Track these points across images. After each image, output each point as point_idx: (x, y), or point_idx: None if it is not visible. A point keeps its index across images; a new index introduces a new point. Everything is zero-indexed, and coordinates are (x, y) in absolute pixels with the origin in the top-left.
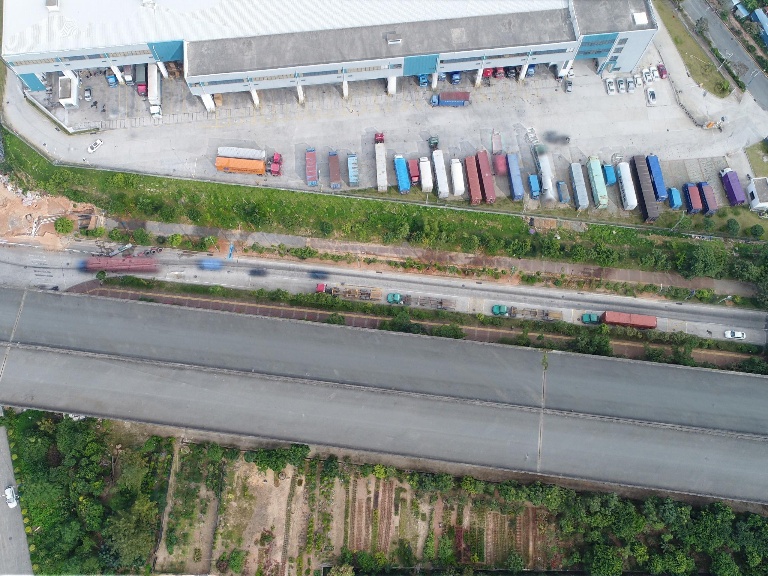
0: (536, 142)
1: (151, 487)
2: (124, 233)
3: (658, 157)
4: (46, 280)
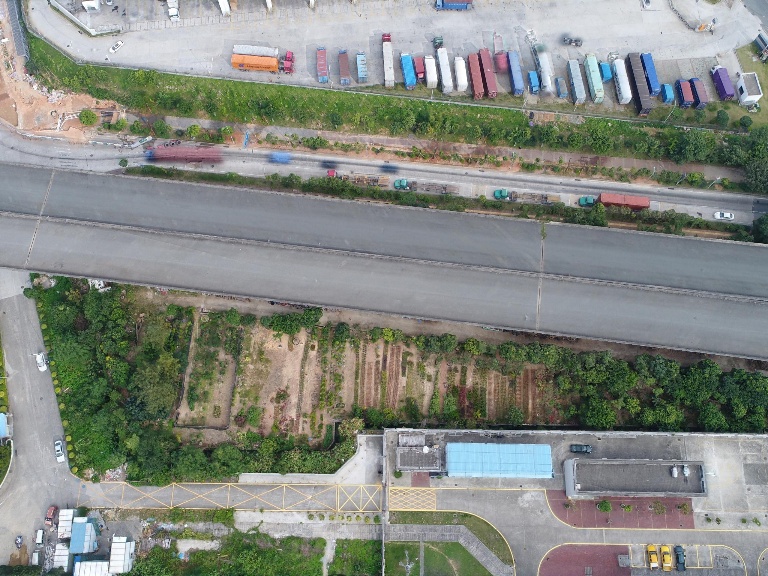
0: (536, 43)
1: (173, 351)
2: (144, 127)
3: (652, 57)
4: None
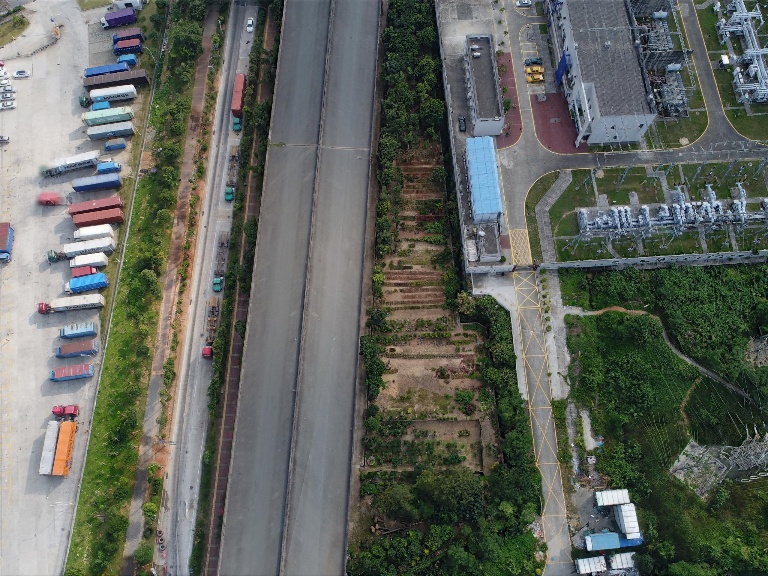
0: (61, 168)
1: None
2: None
3: None
4: None
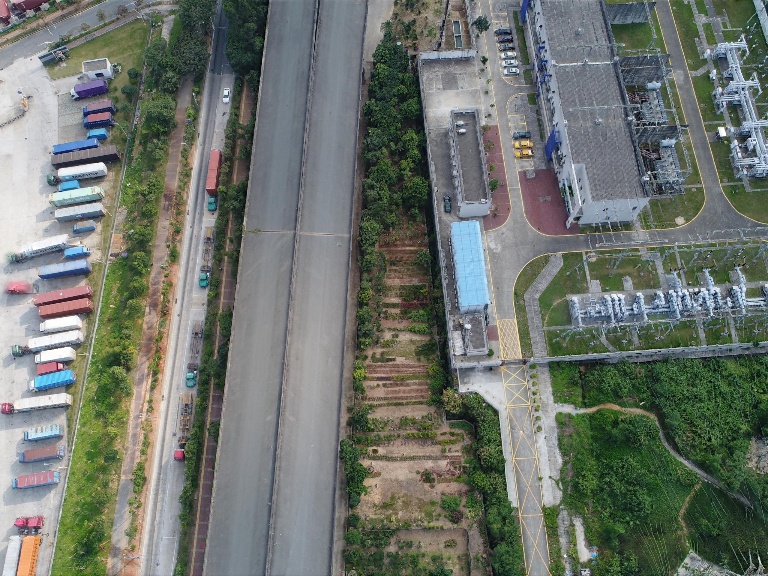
0: (28, 253)
1: None
2: None
3: None
4: None
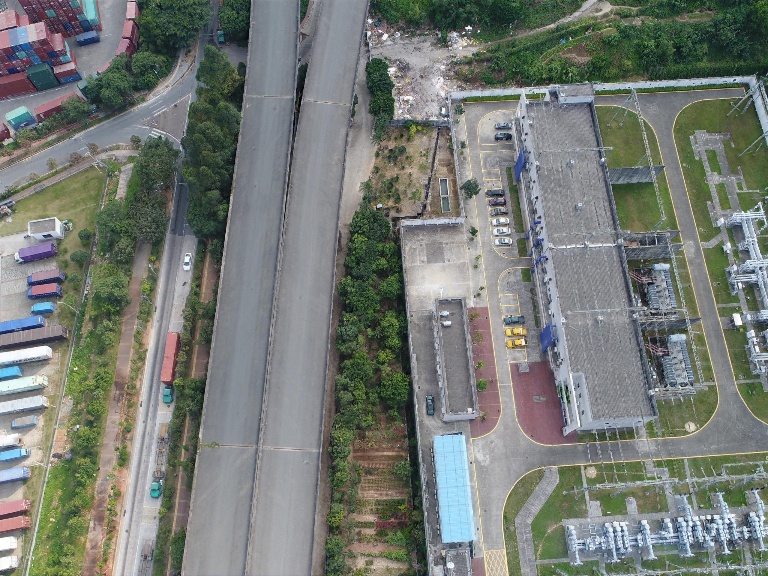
0: None
1: None
2: None
3: None
4: None
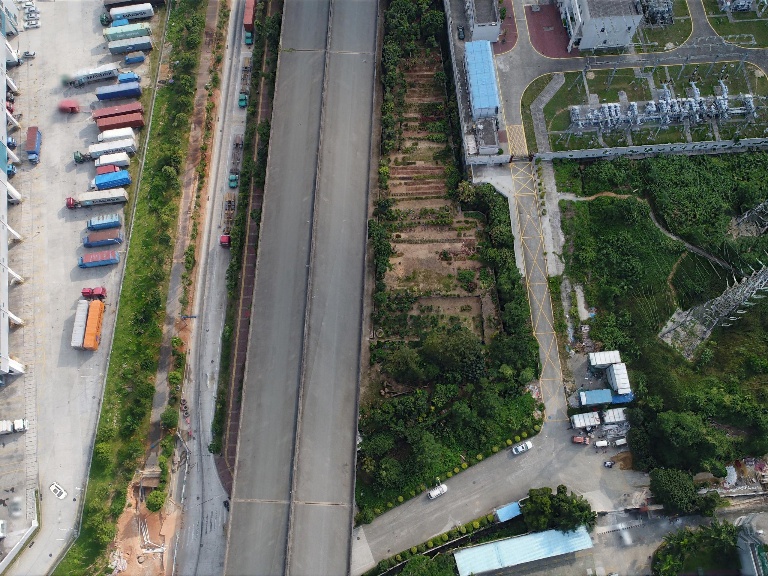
0: (84, 80)
1: None
2: None
3: None
4: (217, 518)
